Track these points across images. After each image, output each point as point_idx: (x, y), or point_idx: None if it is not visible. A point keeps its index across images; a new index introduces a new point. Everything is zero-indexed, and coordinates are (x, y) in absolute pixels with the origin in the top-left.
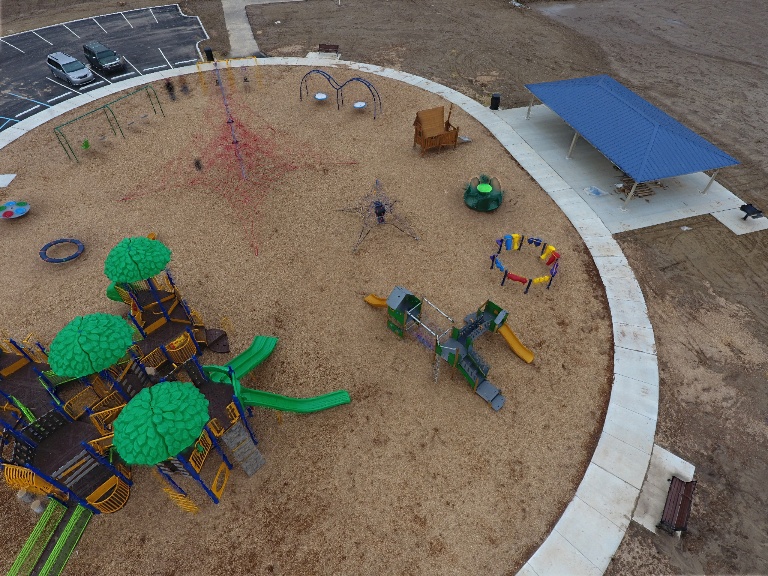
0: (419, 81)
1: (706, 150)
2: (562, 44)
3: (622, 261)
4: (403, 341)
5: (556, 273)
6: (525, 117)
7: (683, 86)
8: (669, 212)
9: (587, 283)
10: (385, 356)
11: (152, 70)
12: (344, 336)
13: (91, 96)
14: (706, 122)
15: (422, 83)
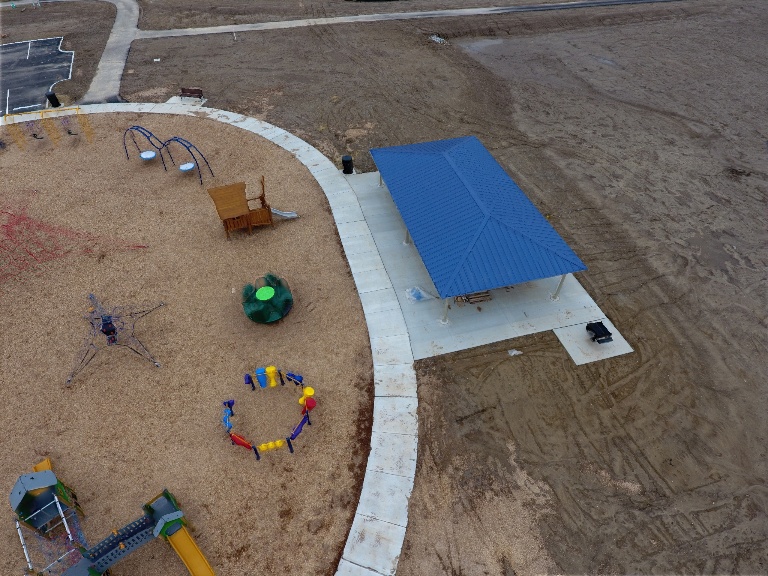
0: (278, 135)
1: (545, 251)
2: (461, 90)
3: (410, 406)
4: (51, 542)
5: (314, 425)
6: (379, 184)
7: (587, 143)
8: (500, 327)
9: (350, 442)
10: (12, 570)
11: None
12: None
13: None
14: (599, 191)
15: (280, 137)
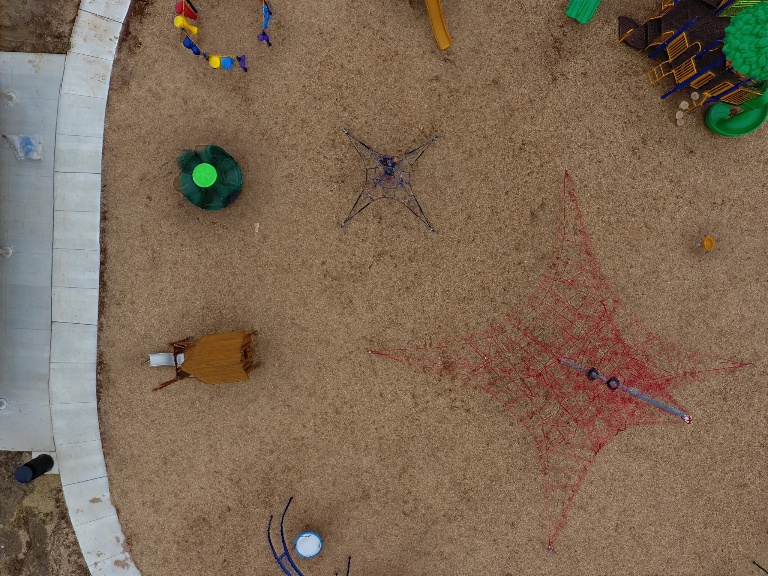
0: None
1: None
2: None
3: (89, 1)
4: None
5: None
6: (3, 408)
7: None
8: None
9: None
10: None
11: None
12: (488, 2)
13: None
14: None
15: None
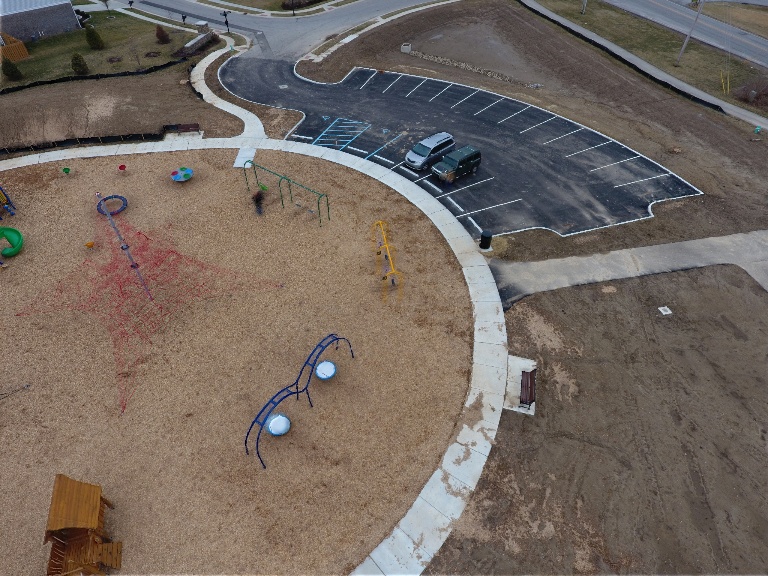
0: (388, 573)
1: None
2: None
3: None
4: None
5: None
6: None
7: None
8: None
9: None
10: None
11: (450, 203)
12: None
13: (384, 175)
14: None
15: None
